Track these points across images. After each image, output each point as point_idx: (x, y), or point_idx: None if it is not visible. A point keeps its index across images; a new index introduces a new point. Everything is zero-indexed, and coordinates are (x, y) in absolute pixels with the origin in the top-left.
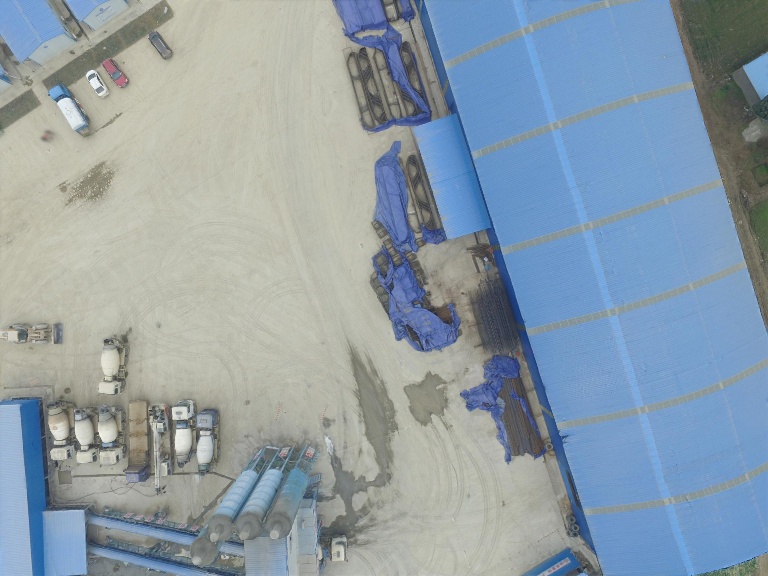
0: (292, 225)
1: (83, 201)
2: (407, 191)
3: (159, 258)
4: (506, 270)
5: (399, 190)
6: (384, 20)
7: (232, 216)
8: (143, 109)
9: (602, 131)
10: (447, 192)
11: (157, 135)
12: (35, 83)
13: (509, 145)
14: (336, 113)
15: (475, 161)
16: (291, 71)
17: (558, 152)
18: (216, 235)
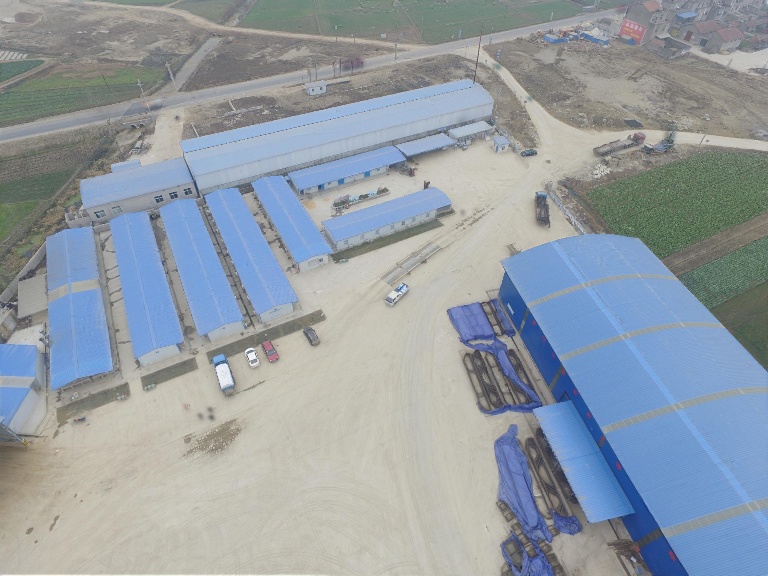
0: (411, 498)
1: (202, 453)
2: (530, 472)
3: (261, 522)
4: (670, 566)
5: (522, 470)
6: (492, 334)
7: (349, 482)
8: (284, 379)
9: (724, 413)
10: (578, 470)
11: (291, 401)
12: (200, 353)
13: (637, 421)
14: (455, 397)
15: (606, 435)
16: (415, 362)
17: (689, 429)
18: (329, 501)
